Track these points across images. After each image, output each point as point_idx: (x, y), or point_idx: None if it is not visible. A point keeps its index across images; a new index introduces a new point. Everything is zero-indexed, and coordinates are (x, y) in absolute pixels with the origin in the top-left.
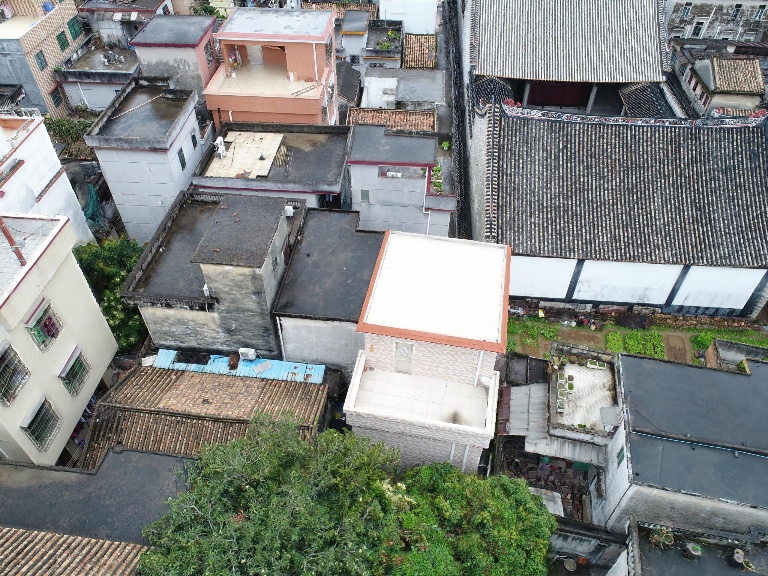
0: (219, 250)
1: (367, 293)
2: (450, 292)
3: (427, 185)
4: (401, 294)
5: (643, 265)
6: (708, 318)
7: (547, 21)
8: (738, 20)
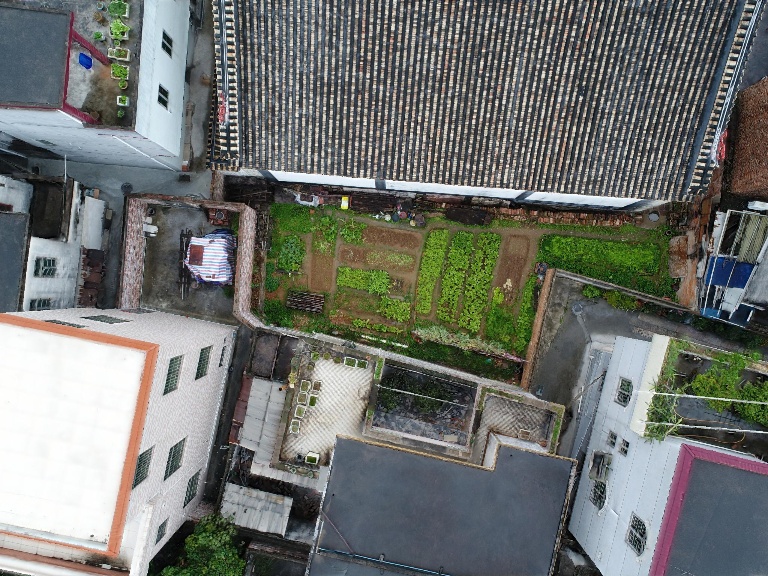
0: None
1: None
2: (54, 447)
3: (75, 116)
4: None
5: None
6: (572, 214)
7: None
8: None
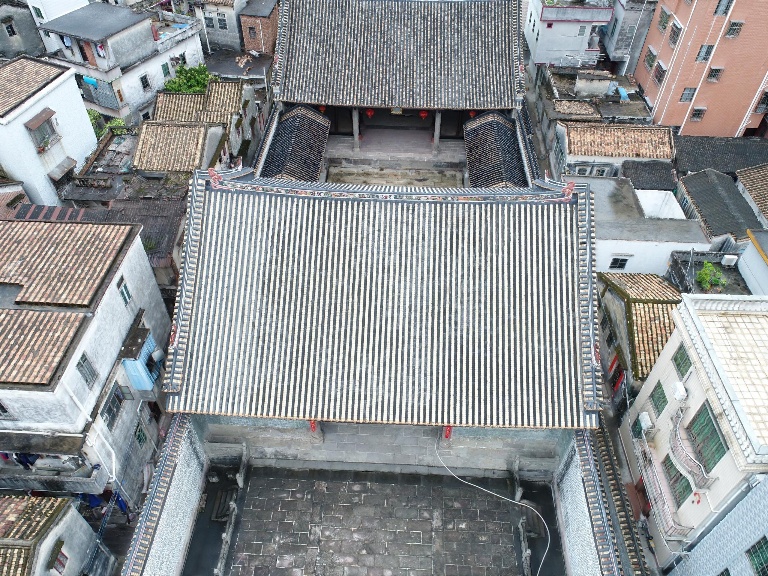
0: None
1: None
2: None
3: None
4: None
5: None
6: None
7: None
8: None
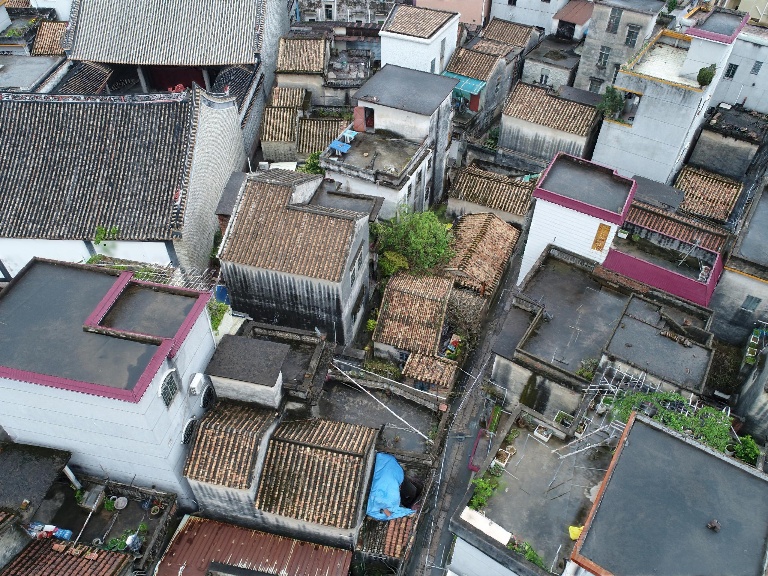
0: None
1: None
2: None
3: None
4: None
5: (45, 241)
6: None
7: (151, 5)
8: (364, 2)
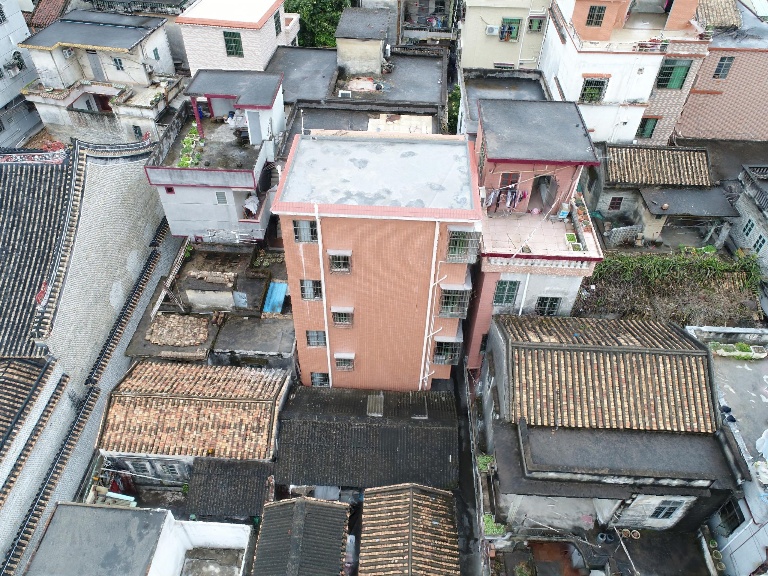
0: (375, 12)
1: (279, 4)
2: (229, 4)
3: None
4: (259, 3)
5: None
6: None
7: None
8: None
